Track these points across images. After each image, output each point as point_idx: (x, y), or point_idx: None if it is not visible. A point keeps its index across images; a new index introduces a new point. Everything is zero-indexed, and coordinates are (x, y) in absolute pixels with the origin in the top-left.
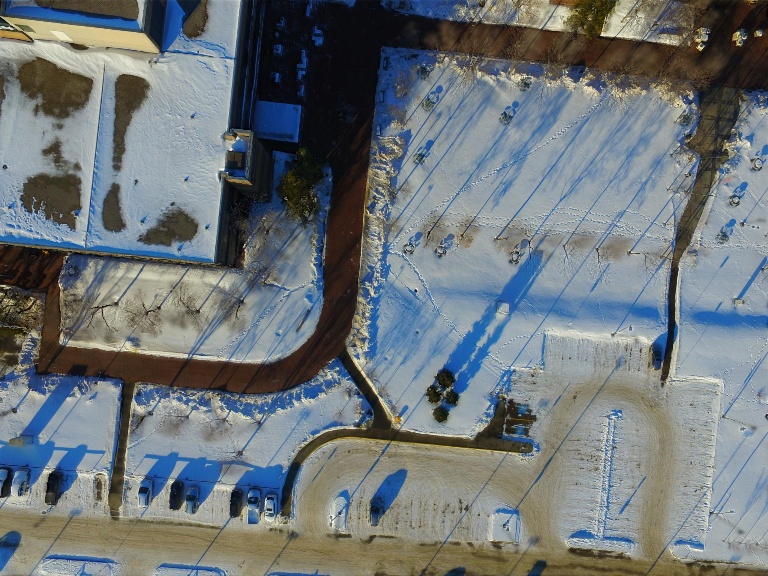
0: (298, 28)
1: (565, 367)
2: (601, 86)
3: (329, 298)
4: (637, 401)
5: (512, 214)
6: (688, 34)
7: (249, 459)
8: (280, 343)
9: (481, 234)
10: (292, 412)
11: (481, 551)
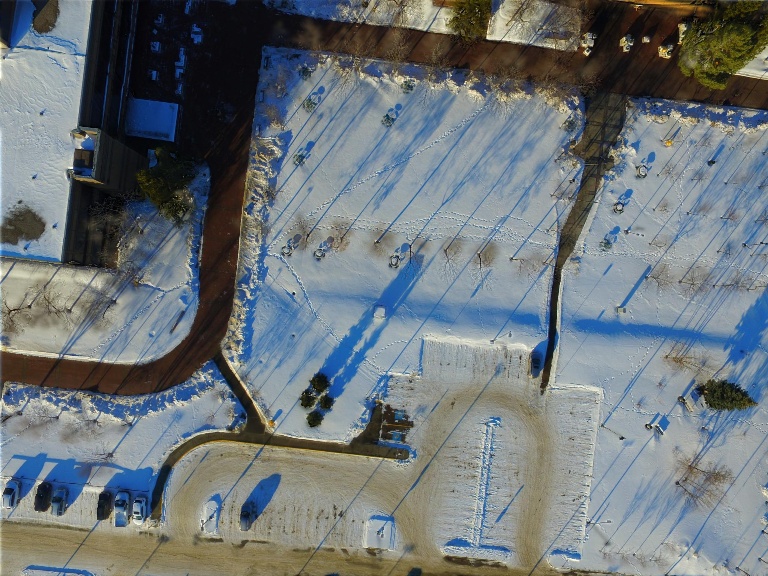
0: (178, 26)
1: (443, 373)
2: (485, 90)
3: (205, 299)
4: (516, 408)
5: (393, 218)
6: (575, 39)
7: (119, 461)
8: (153, 344)
9: (361, 237)
10: (164, 414)
11: (355, 558)
